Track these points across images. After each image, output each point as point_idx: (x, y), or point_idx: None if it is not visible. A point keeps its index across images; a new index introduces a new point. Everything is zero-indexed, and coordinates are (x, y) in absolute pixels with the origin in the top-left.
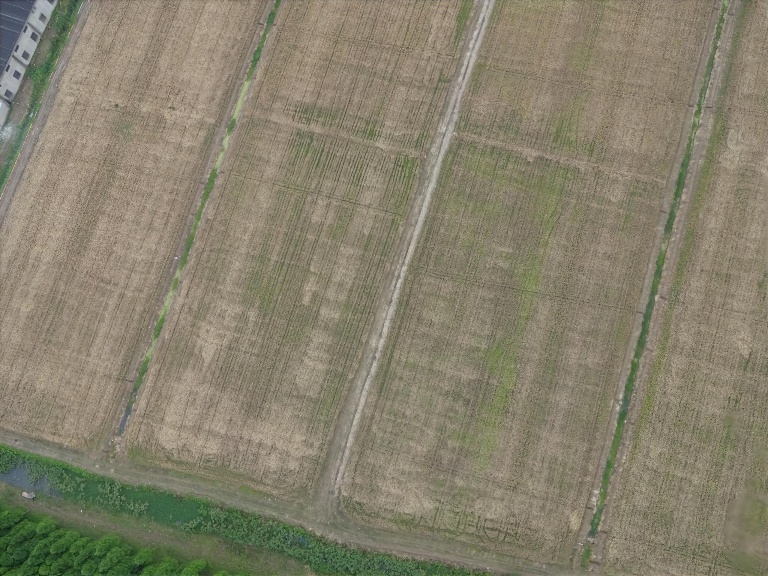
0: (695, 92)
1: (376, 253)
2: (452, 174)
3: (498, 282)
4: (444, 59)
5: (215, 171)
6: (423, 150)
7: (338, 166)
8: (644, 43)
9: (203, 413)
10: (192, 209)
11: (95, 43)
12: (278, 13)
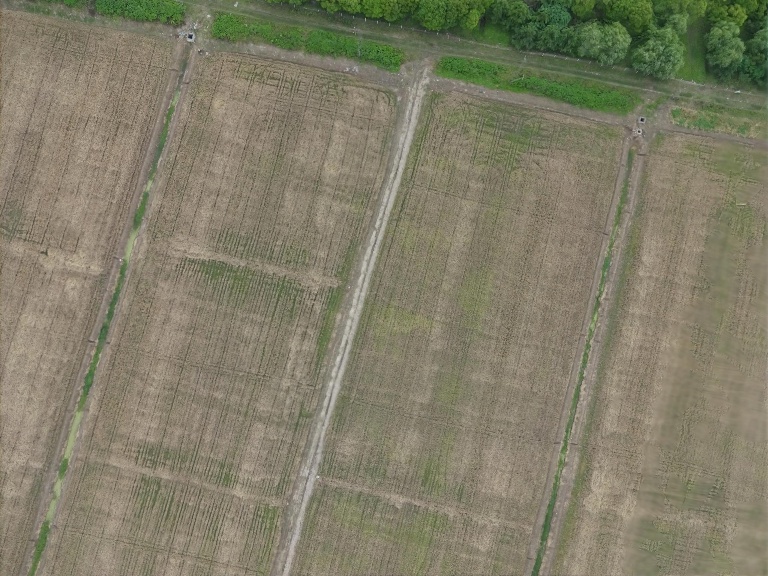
0: (561, 428)
1: None
2: (317, 525)
3: None
4: (305, 390)
5: (47, 524)
6: (285, 498)
7: (191, 517)
8: (512, 374)
9: None
10: (21, 573)
11: None
12: (111, 329)
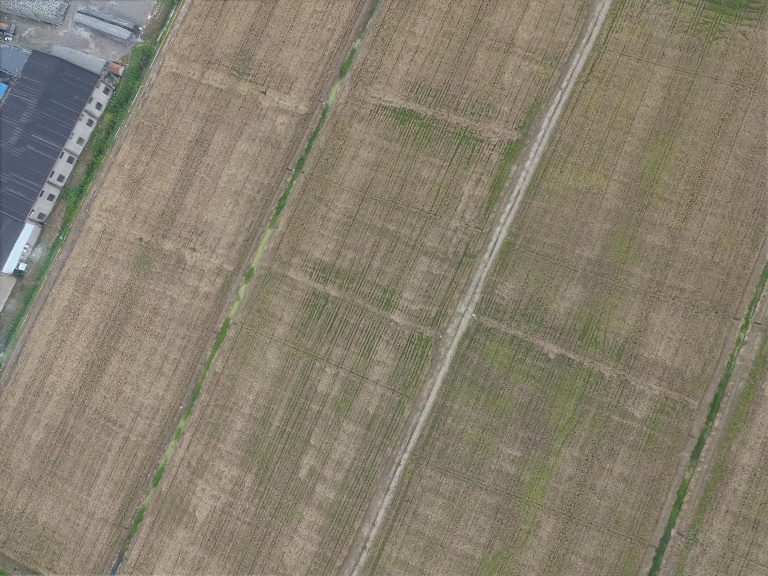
0: (744, 304)
1: (379, 434)
2: (466, 360)
3: (502, 487)
4: (472, 232)
5: (228, 321)
6: (439, 329)
7: (350, 334)
8: (692, 241)
9: (190, 575)
10: (202, 358)
11: (127, 171)
12: (307, 160)
